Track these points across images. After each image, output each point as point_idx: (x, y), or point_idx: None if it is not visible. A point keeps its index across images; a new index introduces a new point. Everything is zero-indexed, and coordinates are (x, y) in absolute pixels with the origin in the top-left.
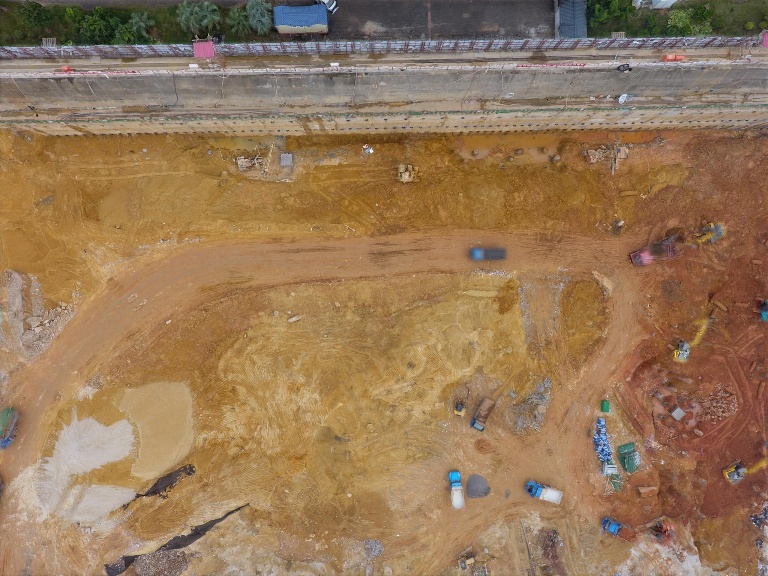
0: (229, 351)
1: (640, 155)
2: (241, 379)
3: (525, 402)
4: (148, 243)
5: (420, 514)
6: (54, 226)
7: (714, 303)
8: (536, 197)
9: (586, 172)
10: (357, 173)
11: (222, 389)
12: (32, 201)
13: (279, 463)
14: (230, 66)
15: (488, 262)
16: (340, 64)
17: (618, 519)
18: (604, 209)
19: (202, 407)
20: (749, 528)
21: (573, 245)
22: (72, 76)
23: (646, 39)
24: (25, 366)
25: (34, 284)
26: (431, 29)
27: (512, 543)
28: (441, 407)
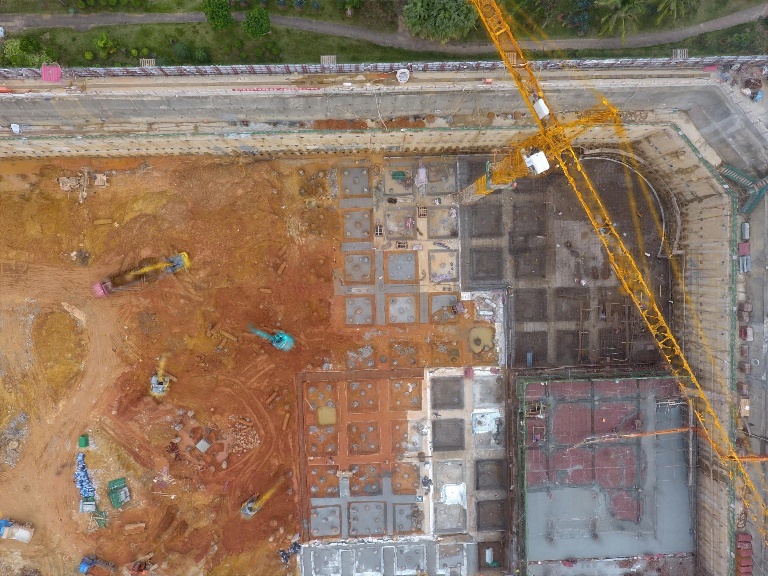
0: None
1: (124, 182)
2: None
3: None
4: None
5: None
6: None
7: (220, 333)
8: None
9: (64, 200)
10: None
11: None
12: None
13: None
14: None
15: None
16: None
17: (104, 557)
18: (69, 238)
19: None
20: (276, 563)
21: (40, 275)
22: None
23: None
24: None
25: None
26: None
27: None
28: None
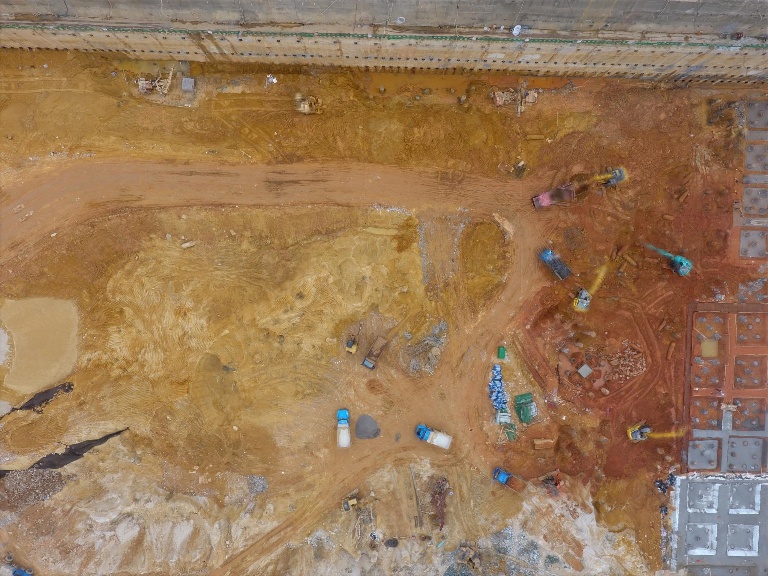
0: (119, 272)
1: (550, 101)
2: (129, 301)
3: (420, 343)
4: (38, 155)
5: (306, 452)
6: None
7: (623, 257)
8: (436, 133)
9: (493, 114)
10: (259, 102)
11: (109, 310)
12: None
13: (160, 387)
14: None
15: (387, 198)
16: None
17: (511, 470)
18: (507, 151)
19: (88, 327)
20: (653, 493)
21: (475, 186)
22: None
23: None
24: None
25: None
26: None
27: (400, 488)
28: (333, 343)
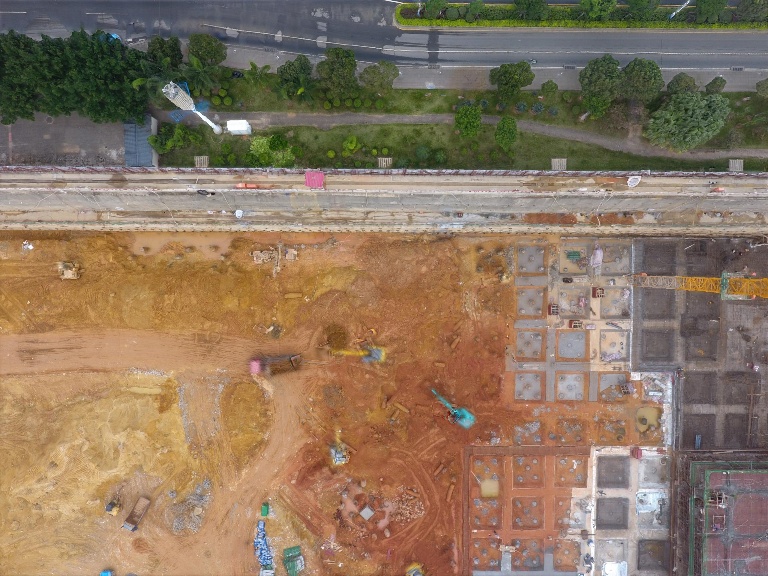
0: None
1: (312, 256)
2: None
3: (183, 502)
4: None
5: None
6: None
7: (394, 405)
8: (186, 300)
9: (255, 272)
10: (16, 269)
11: None
12: None
13: None
14: None
15: (144, 361)
16: None
17: None
18: (263, 312)
19: None
20: None
21: (232, 347)
22: None
23: (211, 168)
24: None
25: None
26: (12, 149)
27: None
28: (96, 505)
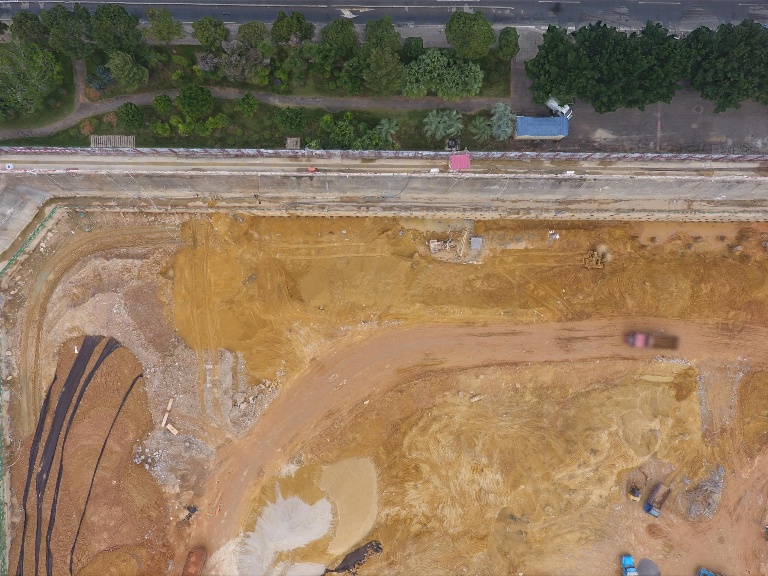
0: (414, 429)
1: None
2: (425, 457)
3: (699, 489)
4: (350, 325)
5: None
6: (262, 306)
7: None
8: (723, 289)
9: (765, 262)
10: (543, 258)
11: (406, 466)
12: (241, 280)
13: (461, 543)
14: (464, 169)
15: (669, 350)
16: (571, 170)
17: None
18: None
19: (386, 483)
20: None
21: (754, 335)
22: (314, 175)
23: None
24: (232, 442)
25: (240, 361)
26: (660, 138)
27: None
28: (615, 491)
